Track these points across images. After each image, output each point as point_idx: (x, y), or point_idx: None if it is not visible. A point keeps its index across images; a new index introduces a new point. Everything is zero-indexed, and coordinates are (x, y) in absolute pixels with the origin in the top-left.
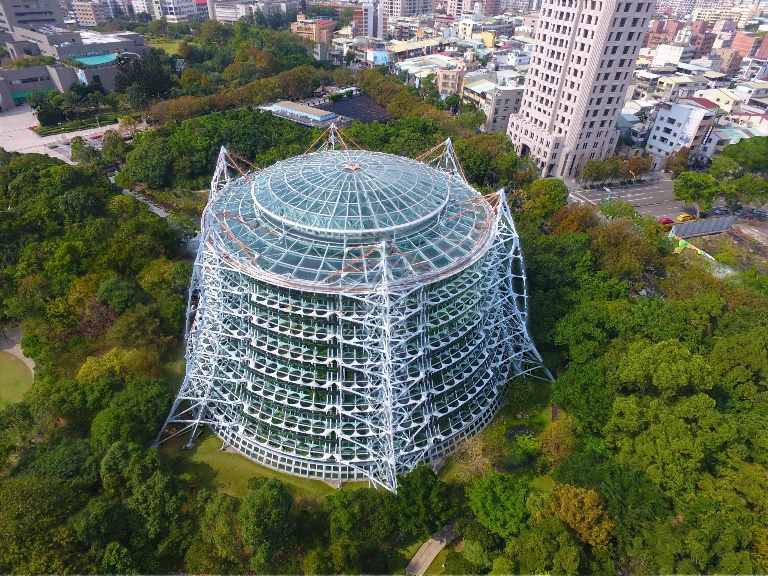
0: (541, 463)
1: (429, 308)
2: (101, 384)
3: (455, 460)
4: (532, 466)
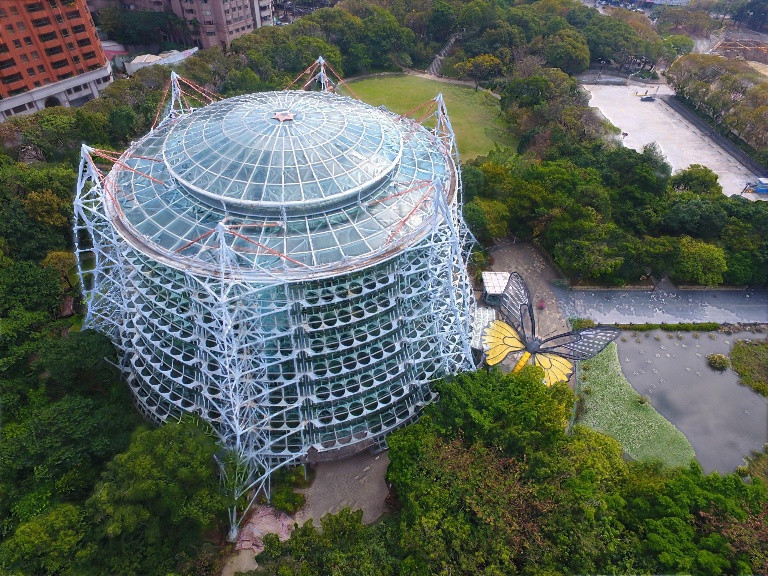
0: None
1: None
2: None
3: None
4: (88, 280)
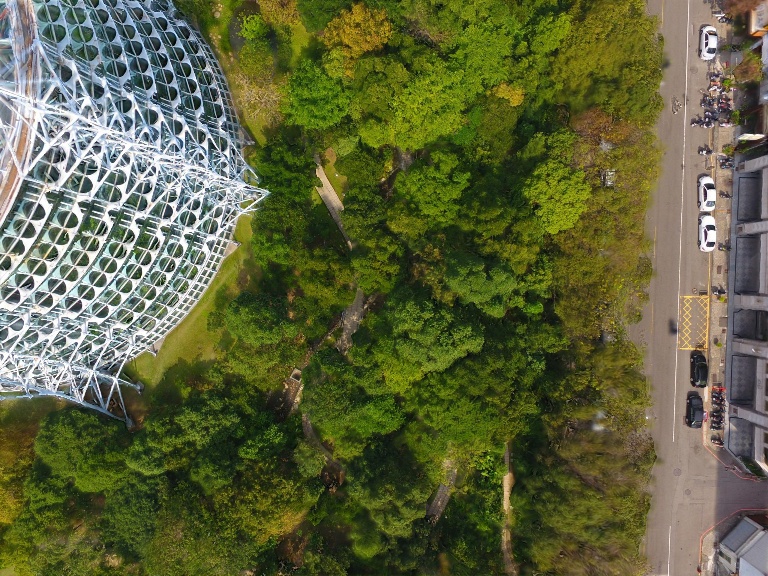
0: (279, 29)
1: (69, 50)
2: (36, 493)
3: (253, 118)
4: (280, 41)
